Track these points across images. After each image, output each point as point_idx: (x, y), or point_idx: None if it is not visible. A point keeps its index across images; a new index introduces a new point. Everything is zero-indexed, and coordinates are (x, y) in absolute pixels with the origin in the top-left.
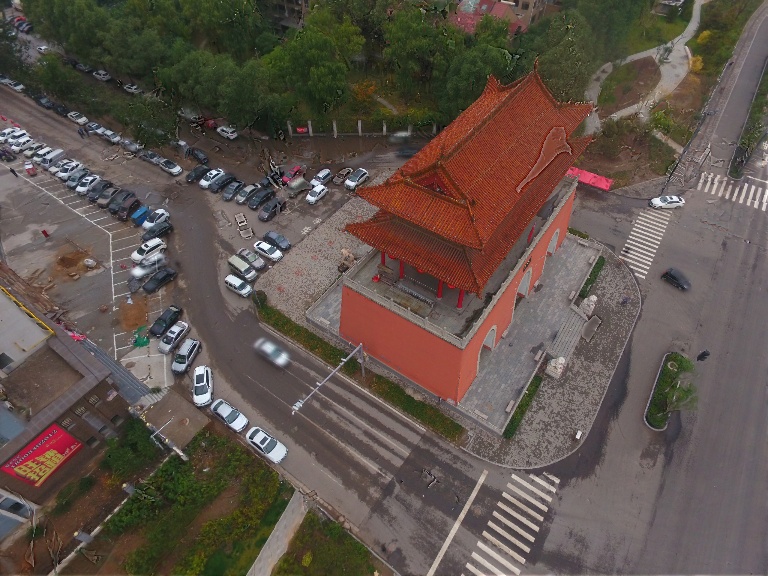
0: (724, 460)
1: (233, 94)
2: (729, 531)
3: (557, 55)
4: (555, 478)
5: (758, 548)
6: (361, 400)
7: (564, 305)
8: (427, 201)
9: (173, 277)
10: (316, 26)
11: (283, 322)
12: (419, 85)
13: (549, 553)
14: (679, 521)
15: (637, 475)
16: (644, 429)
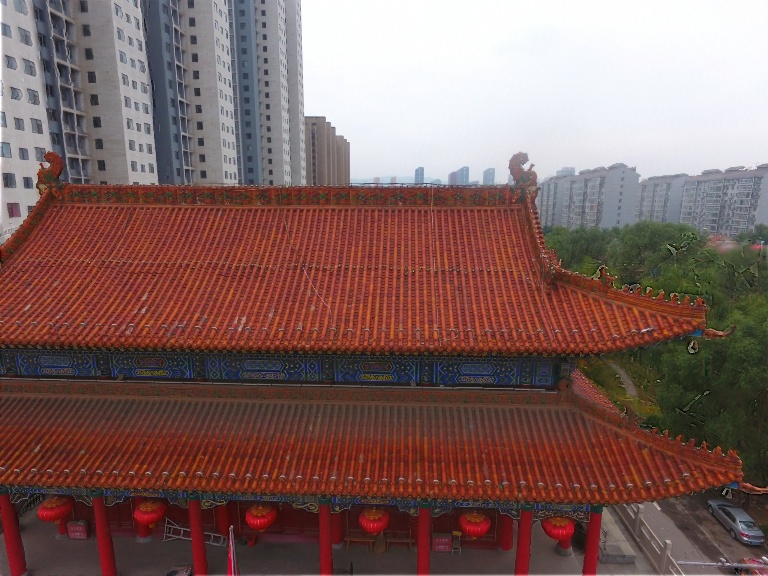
0: None
1: None
2: None
3: None
4: None
5: None
6: None
7: None
8: None
9: None
10: None
11: None
12: None
13: None
14: None
15: None
16: None
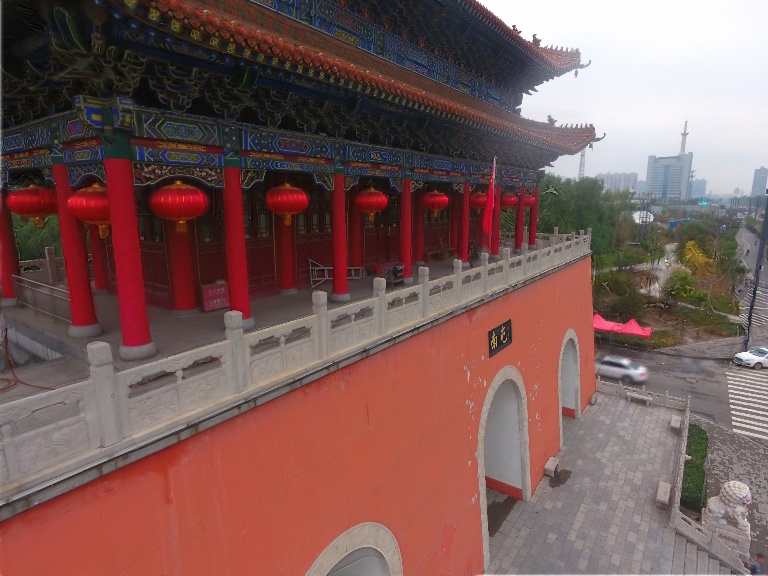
0: None
1: None
2: None
3: None
4: None
5: None
6: None
7: (650, 521)
8: None
9: None
10: None
11: None
12: None
13: None
14: None
15: None
16: None
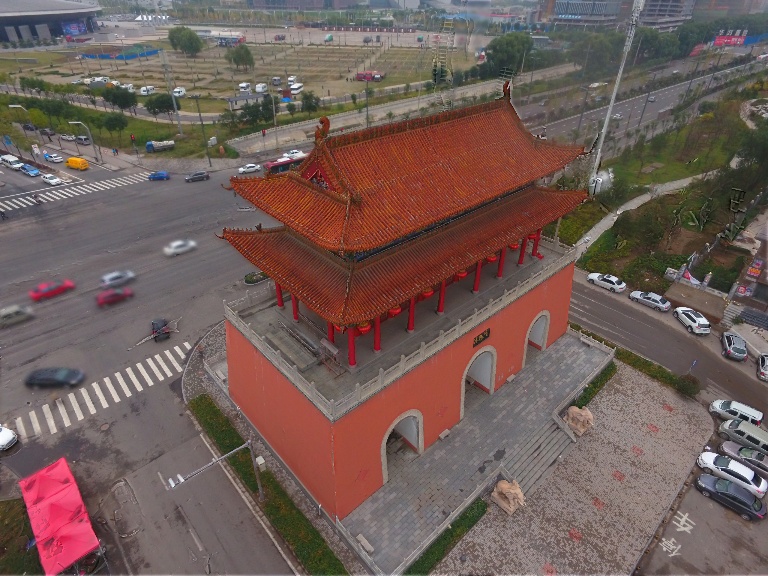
0: None
1: None
2: None
3: None
4: None
5: None
6: None
7: None
8: None
9: None
10: None
11: (640, 360)
12: None
13: None
14: None
15: None
16: None
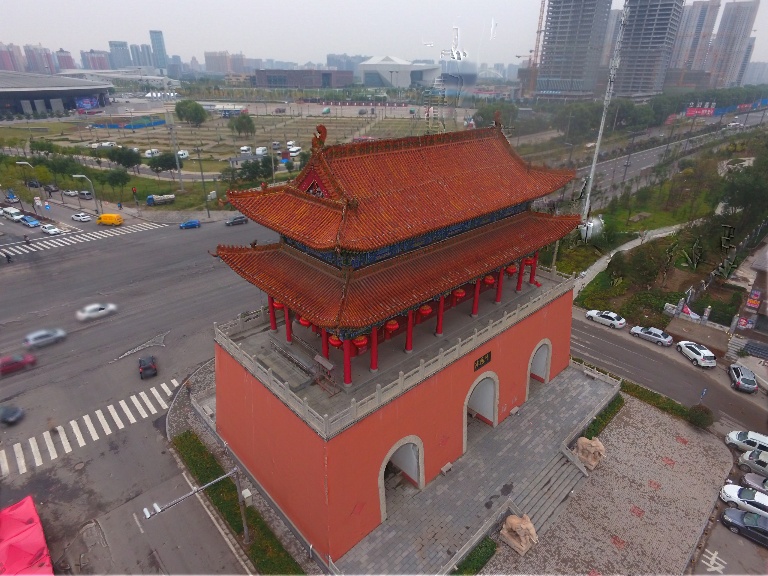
0: None
1: None
2: None
3: None
4: None
5: None
6: None
7: None
8: None
9: None
10: None
11: (647, 392)
12: None
13: None
14: None
15: None
16: None
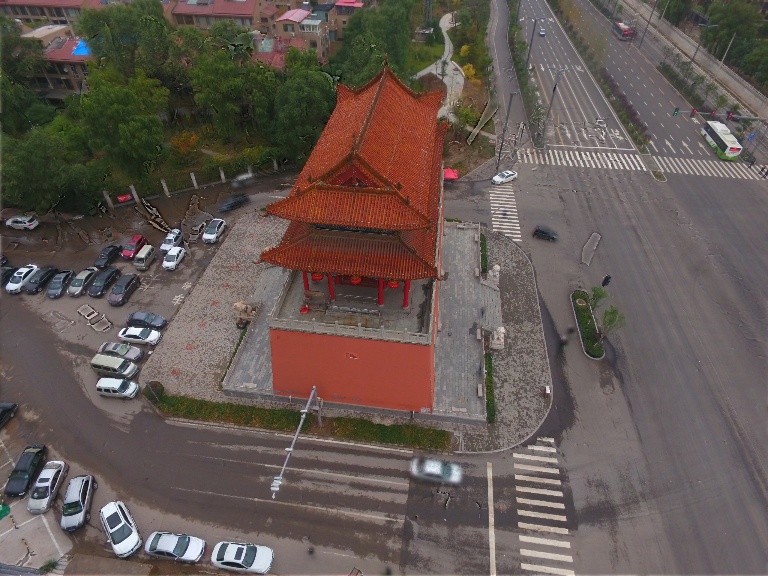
0: (656, 361)
1: (21, 173)
2: (692, 415)
3: (373, 71)
4: (549, 439)
5: (716, 418)
6: (330, 453)
7: (475, 283)
8: (349, 199)
9: (13, 412)
10: (109, 80)
11: (197, 407)
12: (243, 127)
13: (582, 511)
14: (656, 426)
15: (607, 403)
16: (590, 362)
